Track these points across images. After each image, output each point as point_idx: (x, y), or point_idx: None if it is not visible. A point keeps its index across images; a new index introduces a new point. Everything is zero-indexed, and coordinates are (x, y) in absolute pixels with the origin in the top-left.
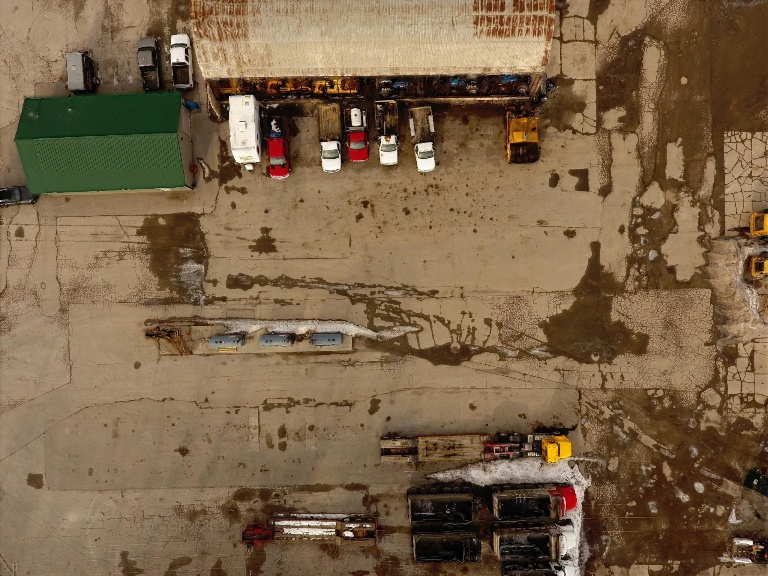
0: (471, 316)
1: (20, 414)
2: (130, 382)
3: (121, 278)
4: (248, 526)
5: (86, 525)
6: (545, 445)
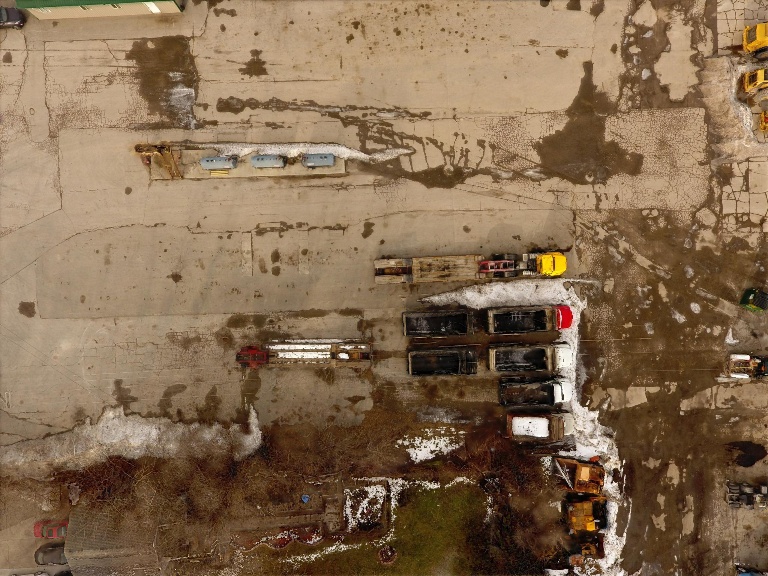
0: (464, 138)
1: (11, 242)
2: (121, 208)
3: (111, 103)
4: (242, 347)
5: (79, 353)
6: (540, 258)
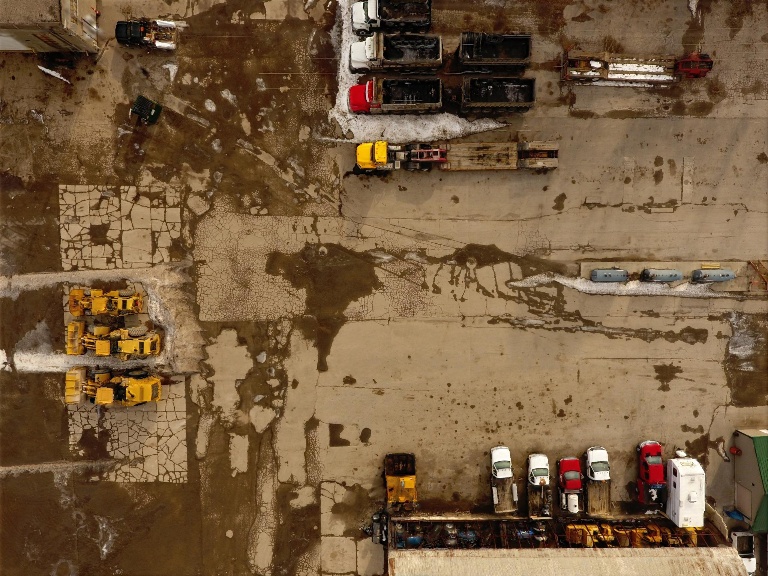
0: (455, 296)
1: None
2: None
3: None
4: None
5: None
6: None
